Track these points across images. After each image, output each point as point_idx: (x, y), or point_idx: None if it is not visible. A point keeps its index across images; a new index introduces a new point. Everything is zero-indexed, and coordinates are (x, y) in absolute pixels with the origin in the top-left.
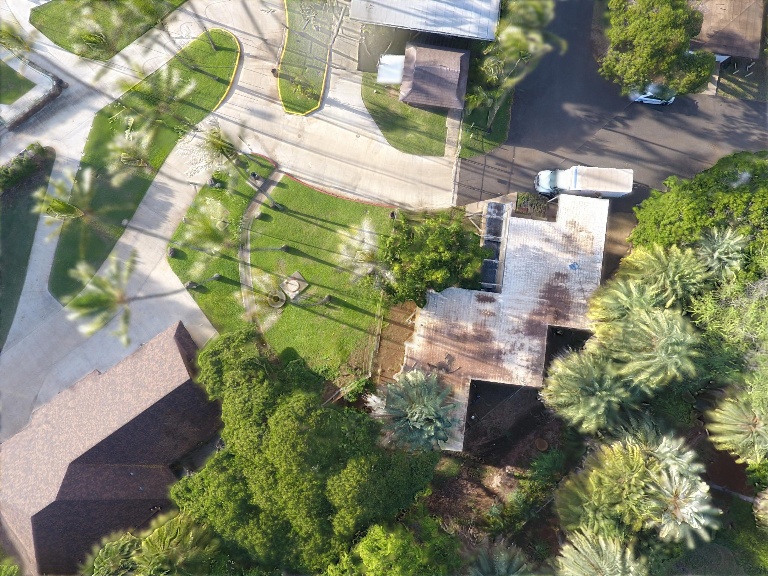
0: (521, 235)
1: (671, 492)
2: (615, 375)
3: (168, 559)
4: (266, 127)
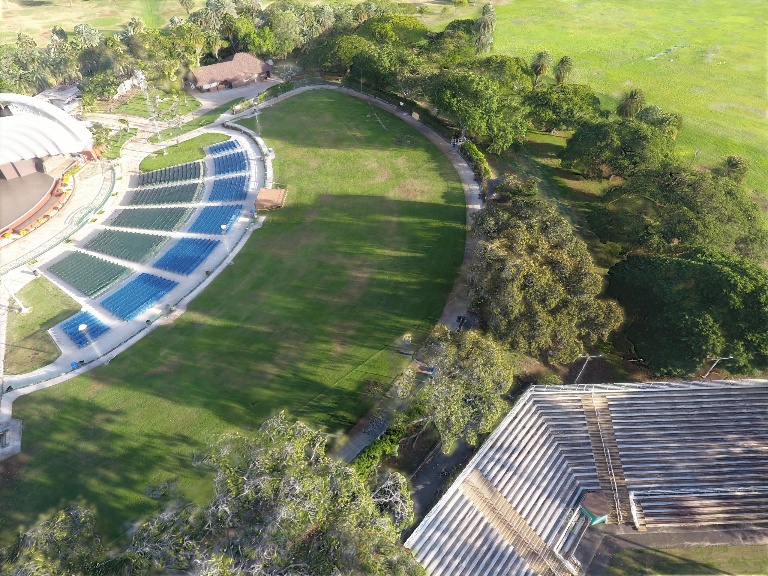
0: (64, 97)
1: (56, 46)
2: (55, 62)
3: (190, 29)
4: (149, 126)
